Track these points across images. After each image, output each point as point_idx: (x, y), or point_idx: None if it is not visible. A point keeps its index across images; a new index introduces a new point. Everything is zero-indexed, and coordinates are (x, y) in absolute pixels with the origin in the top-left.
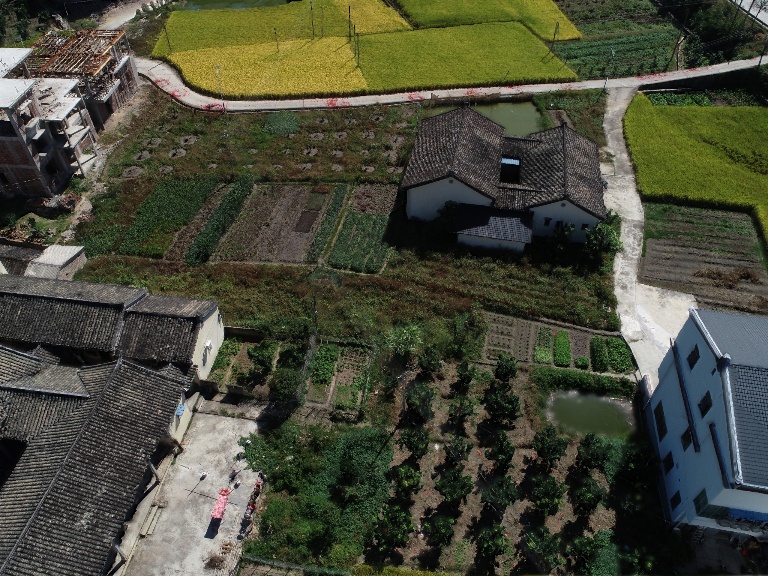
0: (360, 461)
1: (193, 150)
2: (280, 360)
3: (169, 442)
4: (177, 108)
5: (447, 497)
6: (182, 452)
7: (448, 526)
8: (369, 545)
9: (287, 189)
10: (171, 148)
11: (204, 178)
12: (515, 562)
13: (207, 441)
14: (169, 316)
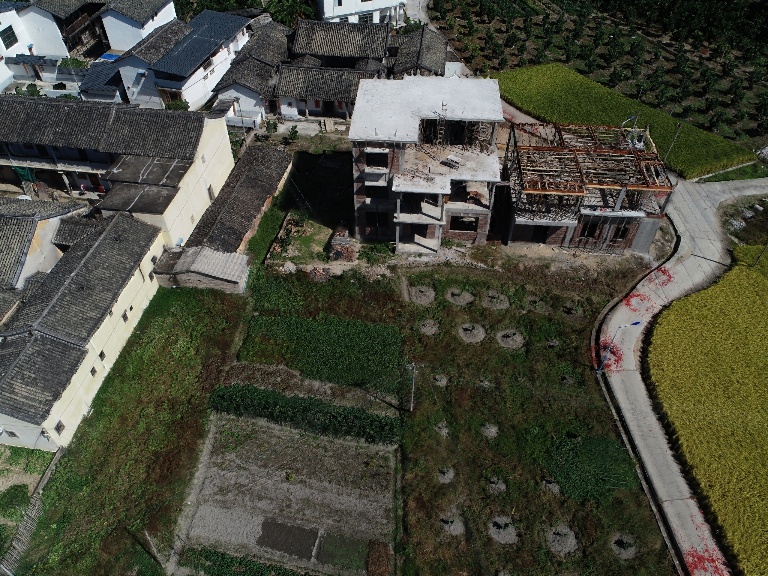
0: None
1: (476, 348)
2: None
3: None
4: (591, 308)
5: None
6: None
7: None
8: None
9: (384, 498)
10: (483, 323)
11: (403, 374)
12: None
13: None
14: (6, 372)
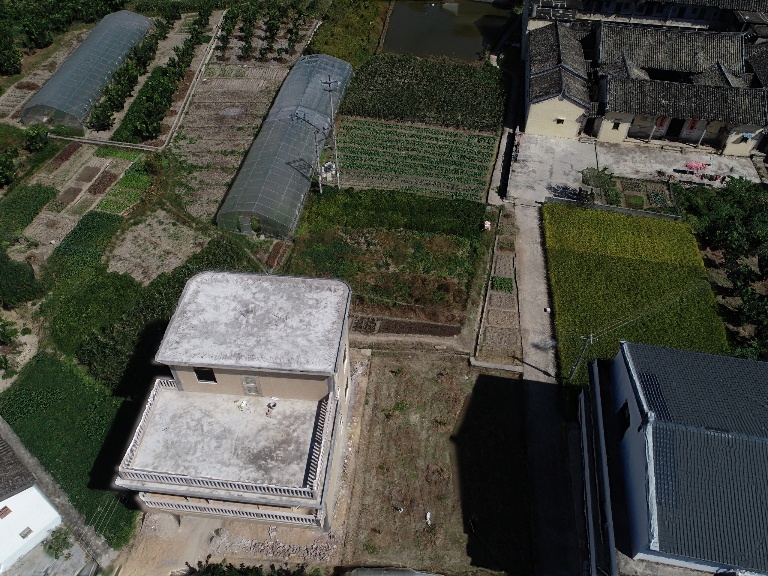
0: (763, 229)
1: None
2: None
3: (723, 144)
4: None
5: (761, 251)
6: (720, 155)
7: (739, 257)
8: (704, 235)
9: None
10: None
11: None
12: (731, 308)
13: (733, 164)
14: None
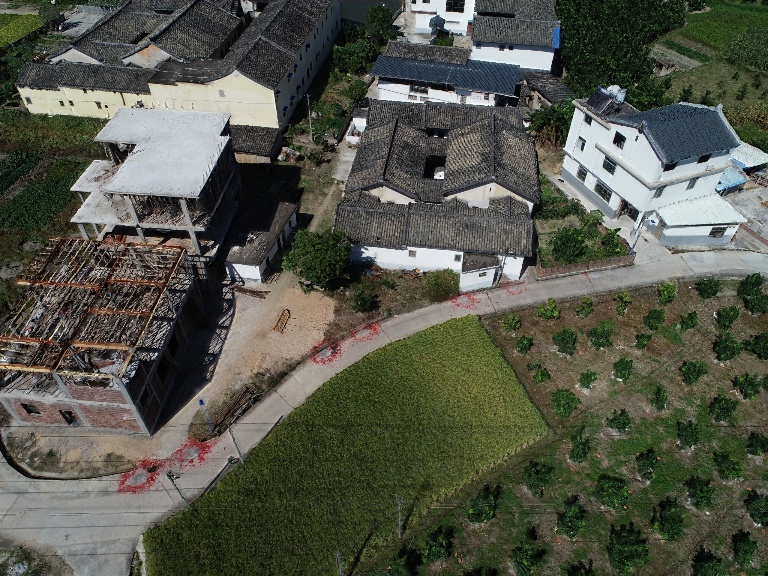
0: None
1: None
2: (1, 102)
3: None
4: None
5: None
6: None
7: None
8: None
9: None
10: None
11: None
12: None
13: None
14: None
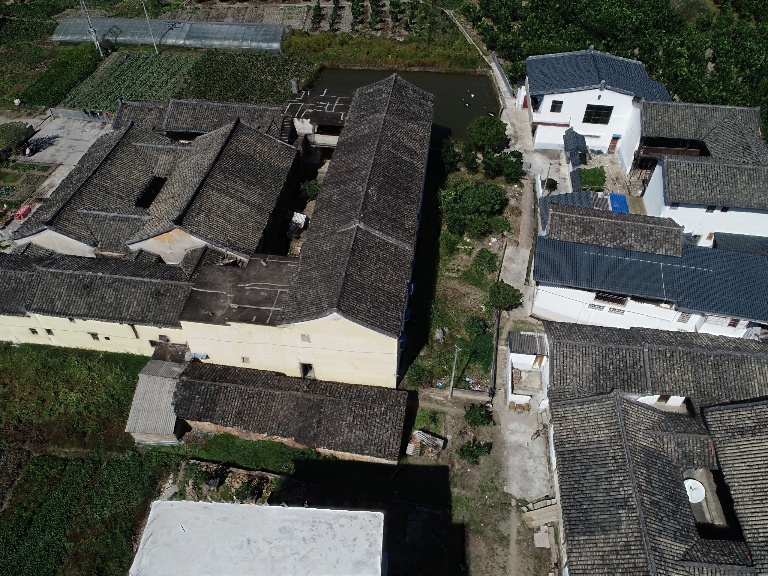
0: None
1: None
2: None
3: None
4: None
5: None
6: None
7: None
8: None
9: None
10: None
11: None
12: None
13: None
14: None
